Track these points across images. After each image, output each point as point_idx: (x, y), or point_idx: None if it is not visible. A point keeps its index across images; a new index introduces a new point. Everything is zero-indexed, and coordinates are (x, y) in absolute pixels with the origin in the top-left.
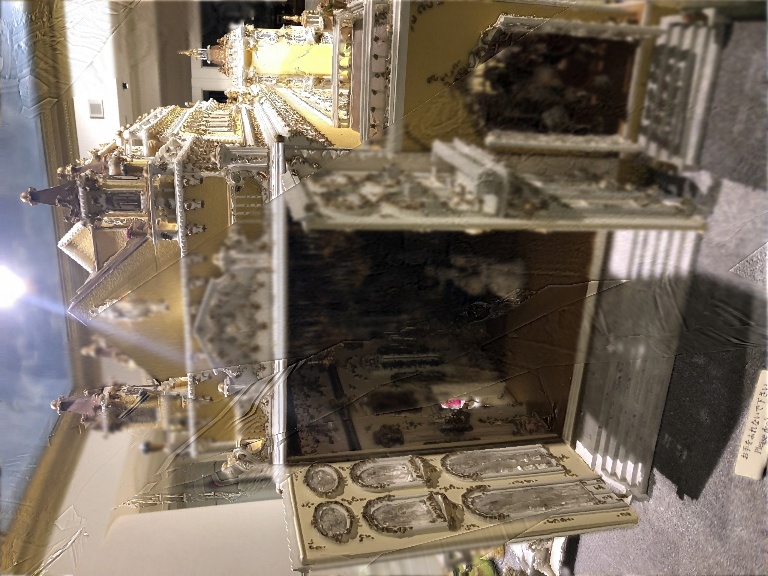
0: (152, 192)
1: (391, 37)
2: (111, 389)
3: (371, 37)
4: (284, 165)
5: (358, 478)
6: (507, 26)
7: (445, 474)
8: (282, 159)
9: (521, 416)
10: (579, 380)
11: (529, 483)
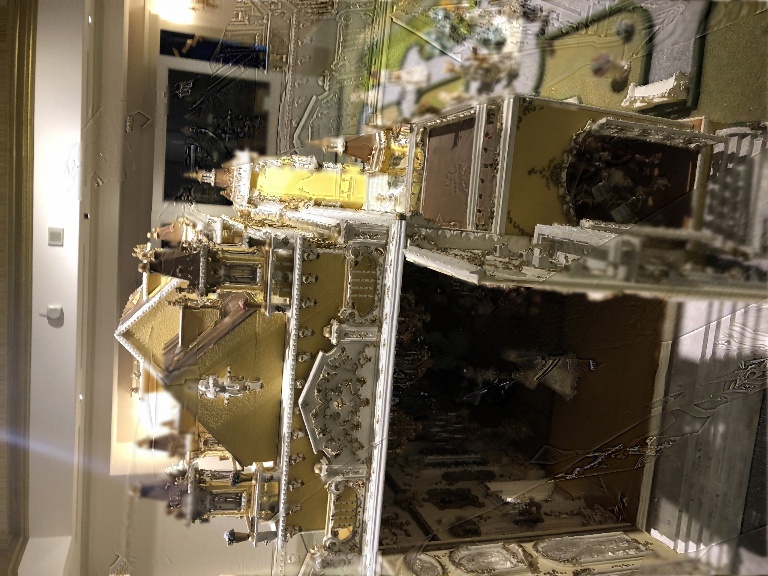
0: (271, 265)
1: (500, 134)
2: None
3: (484, 133)
4: (405, 241)
5: (459, 565)
6: (602, 128)
7: (543, 560)
8: (404, 236)
9: (586, 509)
10: (652, 464)
11: (629, 567)
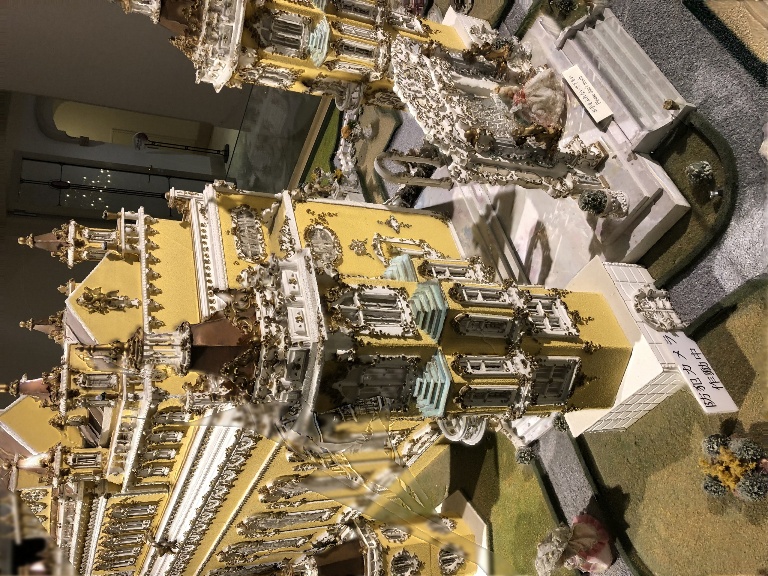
0: None
1: None
2: None
3: None
4: None
5: None
6: None
7: None
8: None
9: None
10: None
11: None
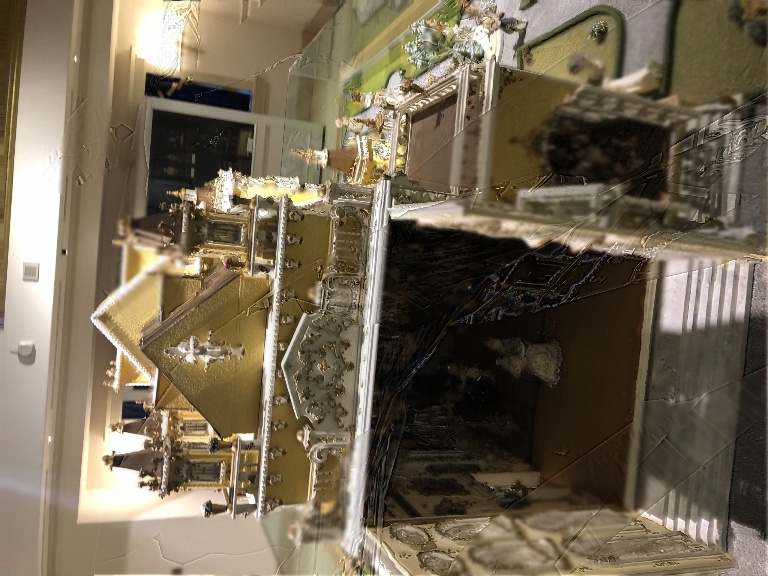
0: (256, 224)
1: (482, 102)
2: None
3: (466, 100)
4: (390, 201)
5: (446, 534)
6: None
7: None
8: (389, 195)
9: None
10: None
11: (619, 537)
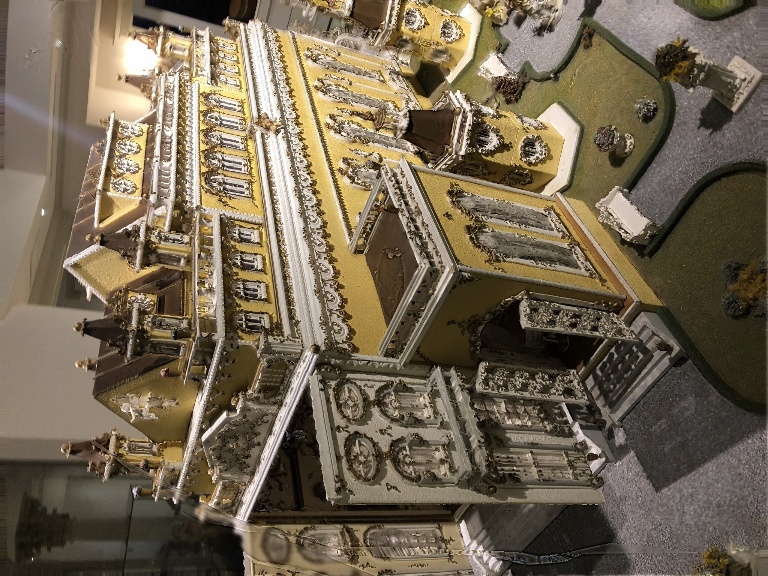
0: (193, 351)
1: (431, 296)
2: (114, 446)
3: None
4: (313, 369)
5: None
6: None
7: None
8: (313, 365)
9: None
10: None
11: (423, 570)
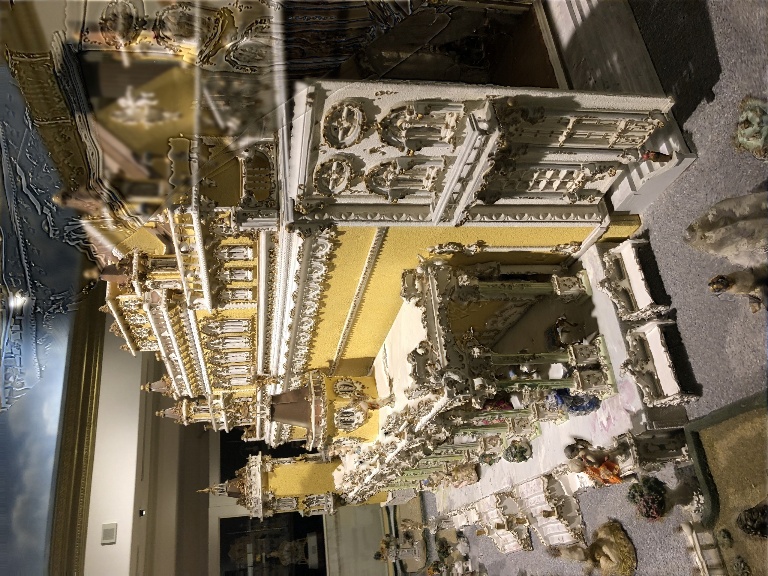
0: None
1: None
2: None
3: None
4: None
5: None
6: None
7: None
8: None
9: None
10: None
11: None
